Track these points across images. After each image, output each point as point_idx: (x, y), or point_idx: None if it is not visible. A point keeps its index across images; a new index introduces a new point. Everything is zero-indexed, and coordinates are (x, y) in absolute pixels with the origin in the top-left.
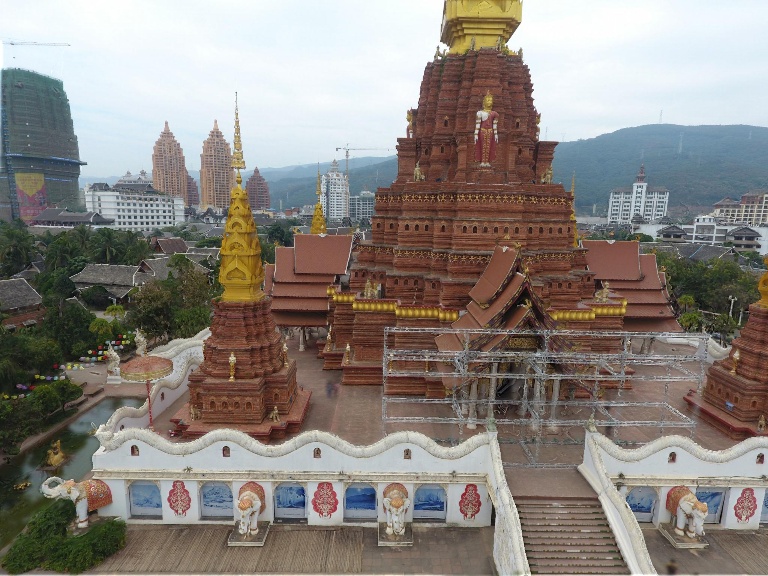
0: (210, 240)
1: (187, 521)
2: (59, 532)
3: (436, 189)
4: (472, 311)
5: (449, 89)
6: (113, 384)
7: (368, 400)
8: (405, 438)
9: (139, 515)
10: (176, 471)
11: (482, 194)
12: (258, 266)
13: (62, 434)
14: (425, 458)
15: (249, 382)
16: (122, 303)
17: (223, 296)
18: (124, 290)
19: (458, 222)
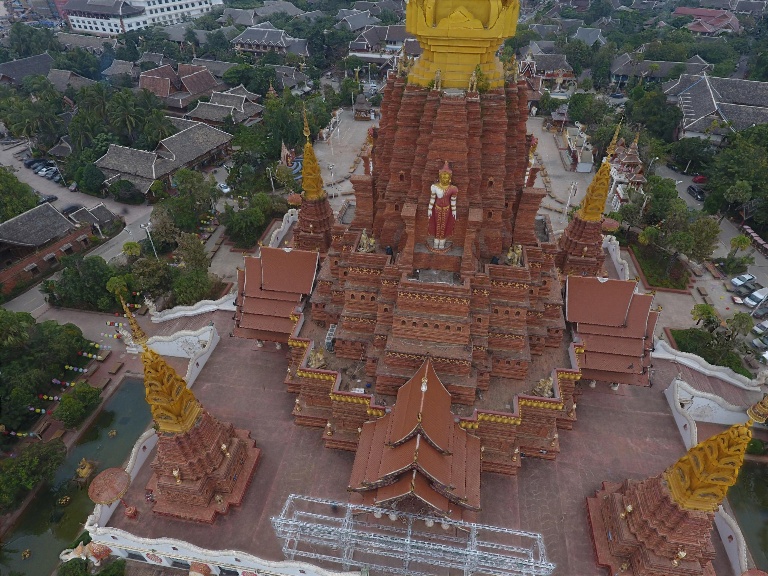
0: (237, 70)
1: (163, 565)
2: (83, 567)
3: (382, 264)
4: (389, 428)
5: (405, 137)
6: (132, 354)
7: (309, 455)
8: (298, 567)
9: (133, 554)
10: (145, 550)
11: (423, 294)
12: (183, 406)
13: (92, 430)
14: (316, 575)
15: (191, 488)
16: (148, 196)
17: (159, 424)
18: (147, 183)
19: (396, 316)
